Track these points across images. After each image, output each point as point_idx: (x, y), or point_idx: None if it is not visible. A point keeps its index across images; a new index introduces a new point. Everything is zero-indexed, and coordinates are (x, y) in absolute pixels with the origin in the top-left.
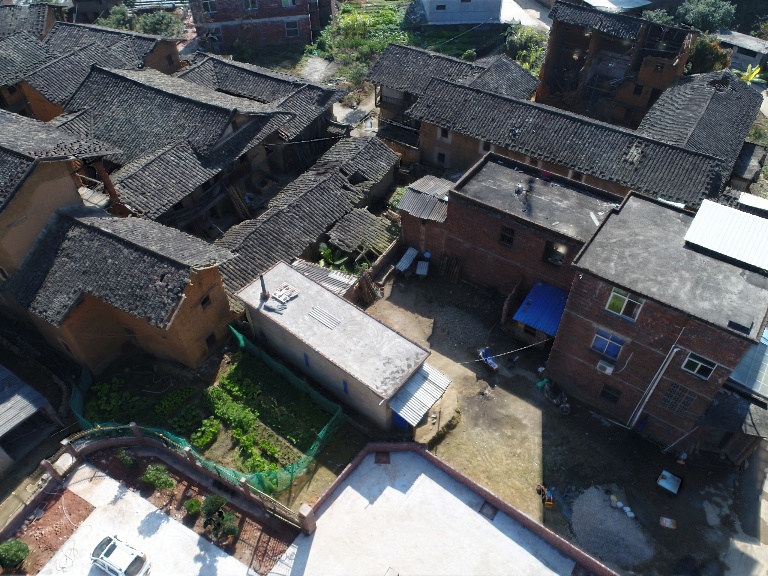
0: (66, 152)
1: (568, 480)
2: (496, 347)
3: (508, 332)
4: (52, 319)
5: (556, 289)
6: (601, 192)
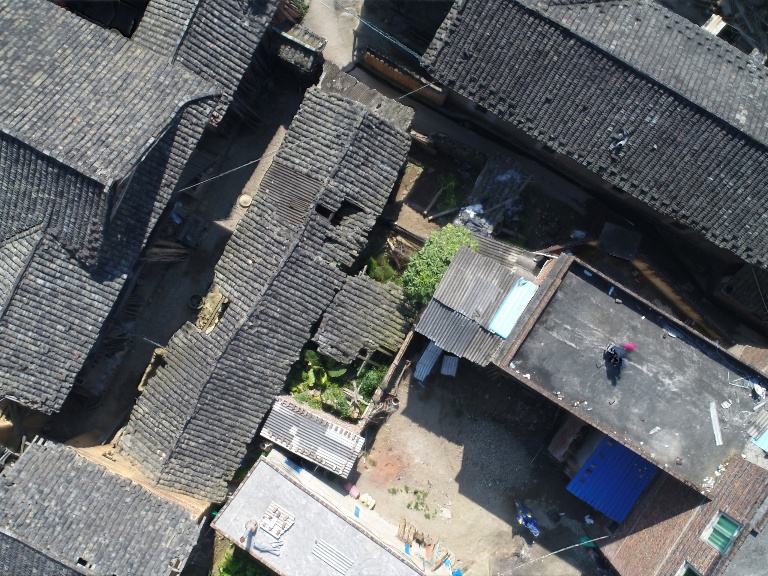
0: None
1: None
2: (539, 485)
3: (555, 461)
4: None
5: (630, 452)
6: (738, 361)
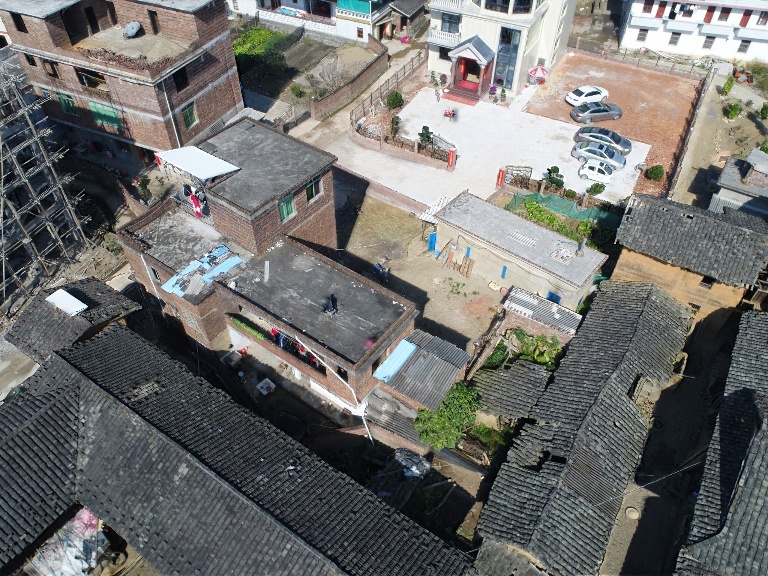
0: None
1: (342, 216)
2: None
3: None
4: (733, 209)
5: None
6: None
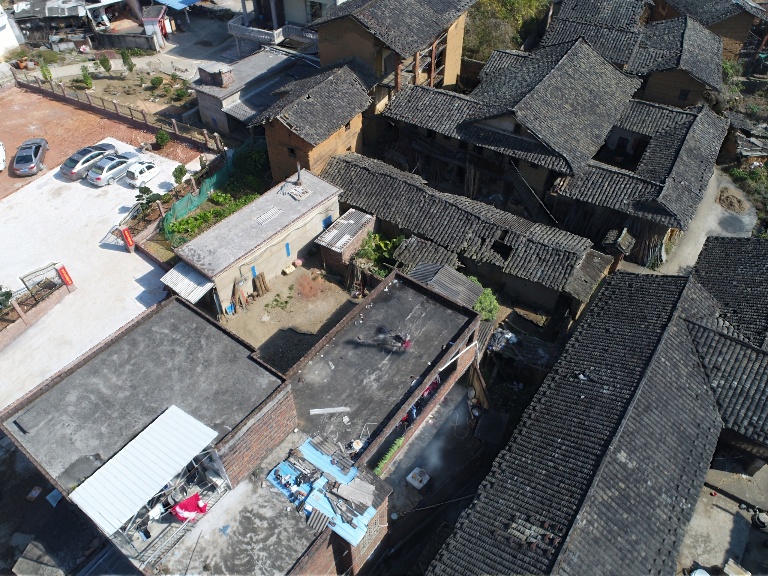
0: (379, 28)
1: None
2: None
3: None
4: (276, 90)
5: None
6: None
